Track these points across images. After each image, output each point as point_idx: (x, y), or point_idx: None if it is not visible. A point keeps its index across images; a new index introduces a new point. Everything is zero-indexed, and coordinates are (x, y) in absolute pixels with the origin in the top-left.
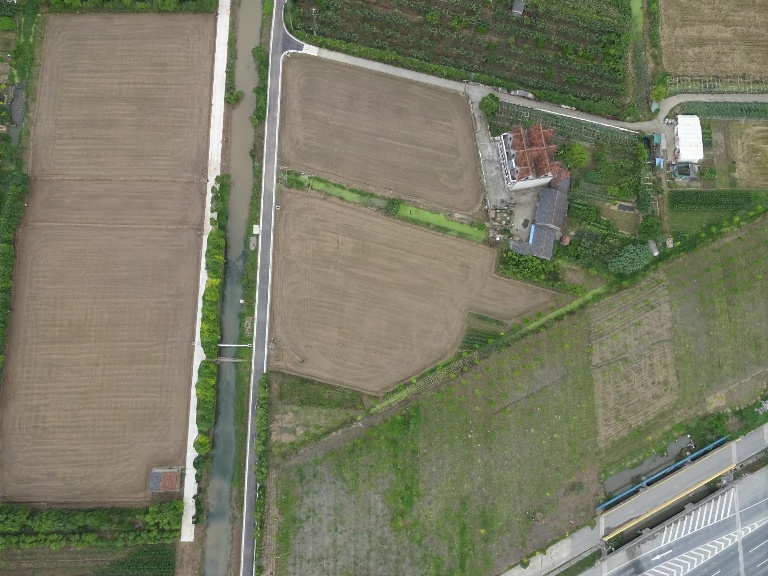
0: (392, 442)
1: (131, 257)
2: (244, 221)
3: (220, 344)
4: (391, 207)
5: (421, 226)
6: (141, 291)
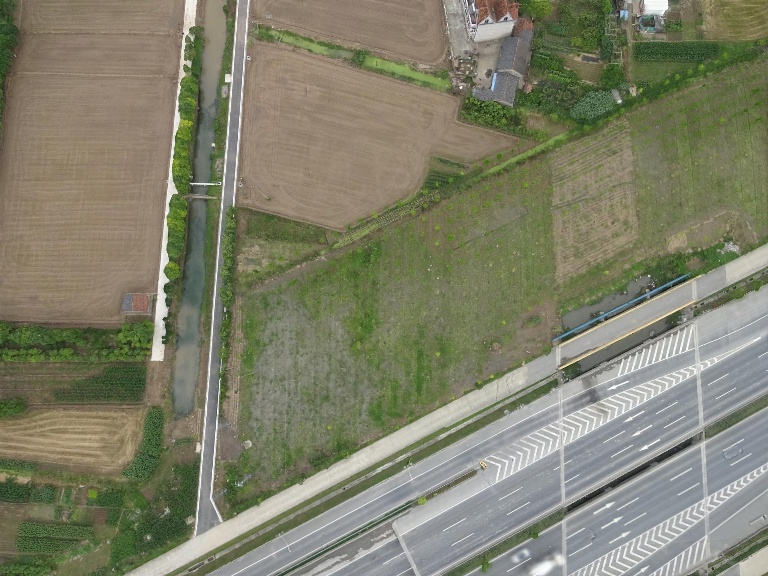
0: (353, 273)
1: (111, 103)
2: (217, 72)
3: (192, 183)
4: (357, 57)
5: (386, 76)
6: (119, 134)
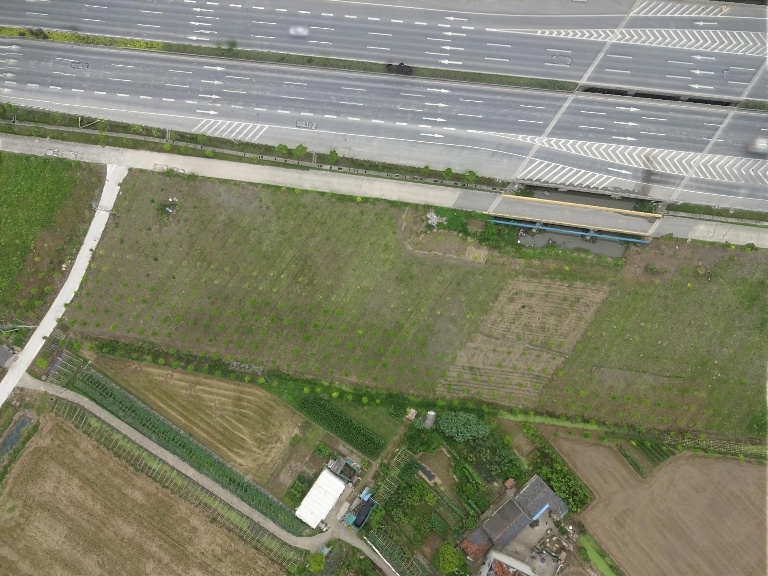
0: None
1: None
2: None
3: None
4: None
5: None
6: None
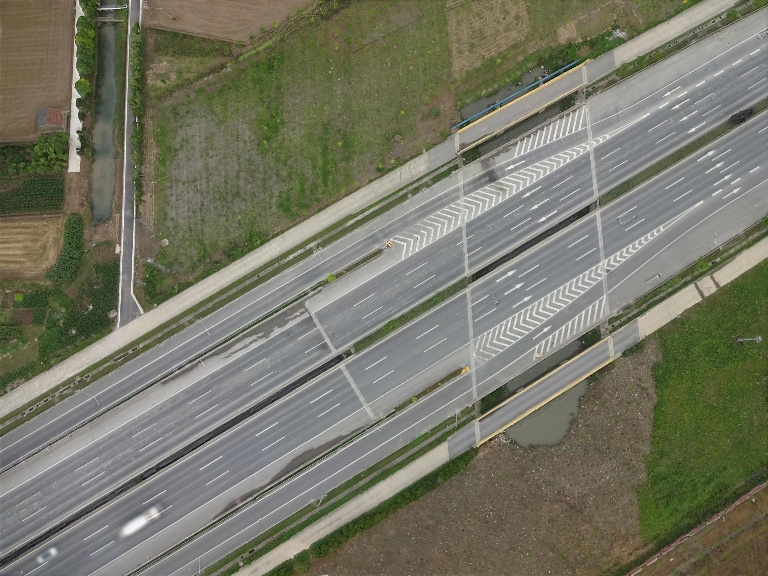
0: (257, 79)
1: None
2: None
3: (99, 8)
4: None
5: None
6: None
